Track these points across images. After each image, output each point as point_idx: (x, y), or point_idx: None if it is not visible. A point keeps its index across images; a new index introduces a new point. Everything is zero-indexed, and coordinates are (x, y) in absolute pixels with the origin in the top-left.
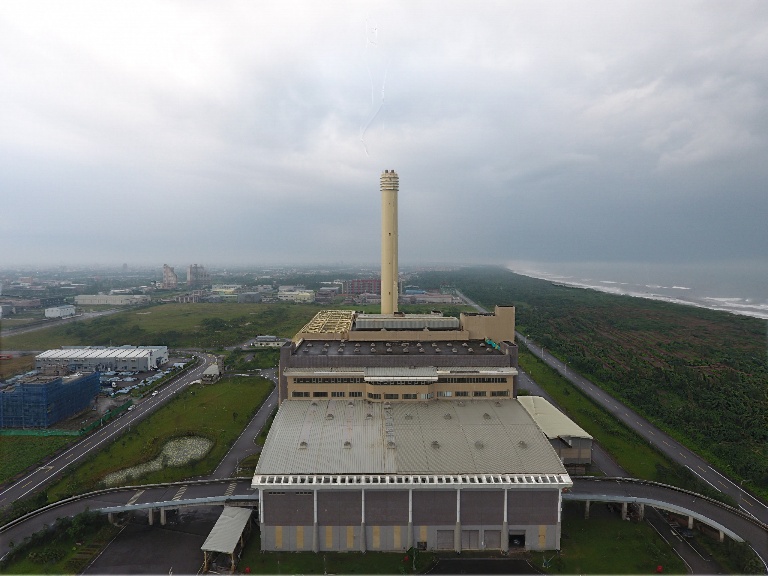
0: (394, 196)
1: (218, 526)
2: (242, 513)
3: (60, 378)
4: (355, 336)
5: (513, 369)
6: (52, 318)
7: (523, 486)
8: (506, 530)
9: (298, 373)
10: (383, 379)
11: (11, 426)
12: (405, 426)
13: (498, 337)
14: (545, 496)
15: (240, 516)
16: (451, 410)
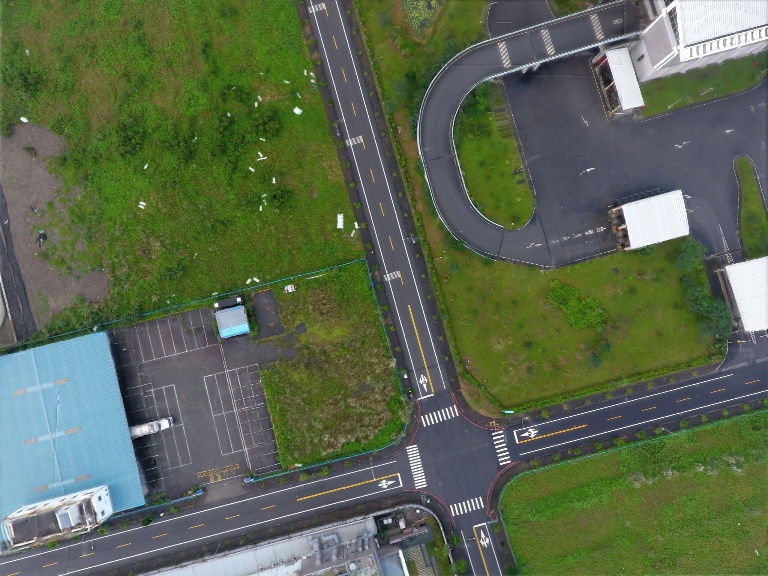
0: None
1: (618, 80)
2: (624, 56)
3: None
4: None
5: None
6: None
7: None
8: None
9: None
10: None
11: None
12: None
13: None
14: None
15: (625, 61)
16: None
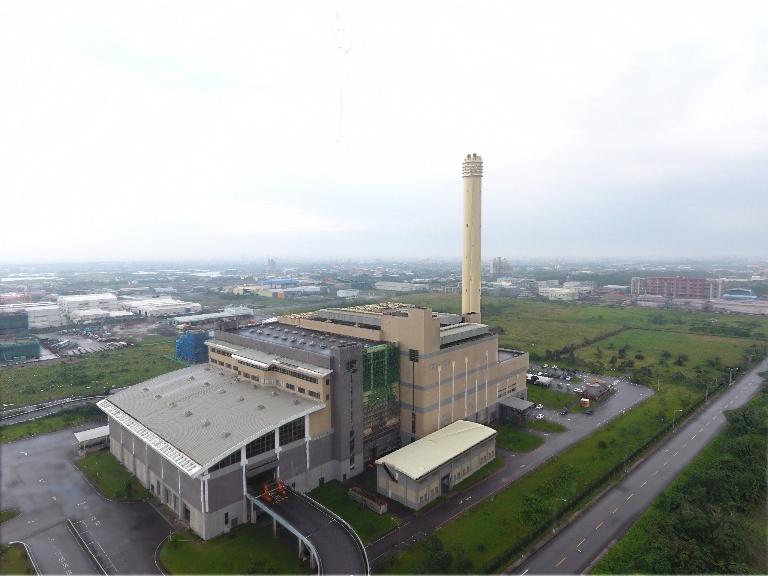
0: (473, 183)
1: (101, 427)
2: None
3: (207, 332)
4: (303, 323)
5: (325, 371)
6: (340, 298)
7: (171, 462)
8: (179, 500)
9: (209, 343)
10: (238, 358)
11: (185, 358)
12: (206, 397)
13: (409, 342)
14: (196, 482)
15: None
16: (257, 396)
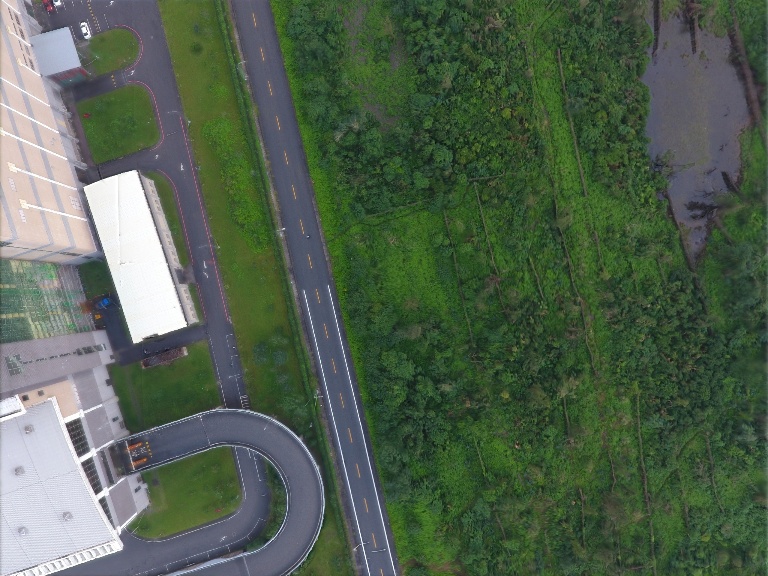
0: None
1: None
2: None
3: None
4: None
5: (15, 406)
6: None
7: None
8: None
9: None
10: None
11: None
12: None
13: None
14: None
15: None
16: None
